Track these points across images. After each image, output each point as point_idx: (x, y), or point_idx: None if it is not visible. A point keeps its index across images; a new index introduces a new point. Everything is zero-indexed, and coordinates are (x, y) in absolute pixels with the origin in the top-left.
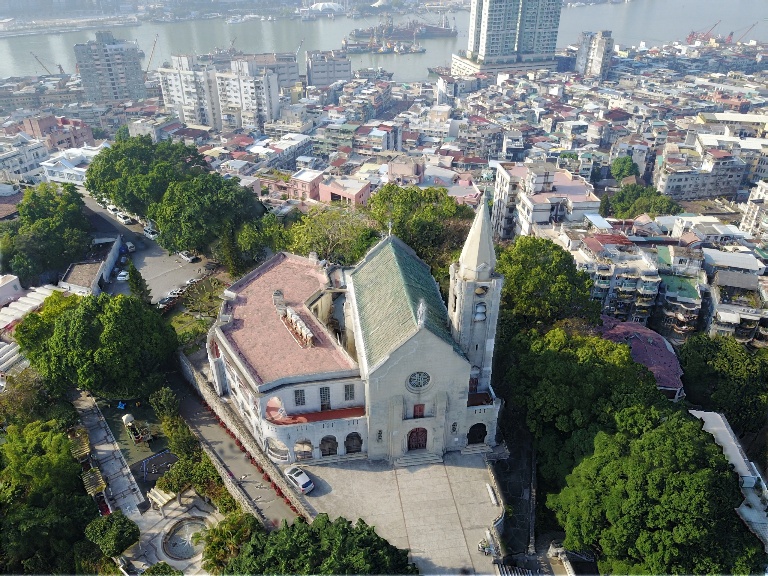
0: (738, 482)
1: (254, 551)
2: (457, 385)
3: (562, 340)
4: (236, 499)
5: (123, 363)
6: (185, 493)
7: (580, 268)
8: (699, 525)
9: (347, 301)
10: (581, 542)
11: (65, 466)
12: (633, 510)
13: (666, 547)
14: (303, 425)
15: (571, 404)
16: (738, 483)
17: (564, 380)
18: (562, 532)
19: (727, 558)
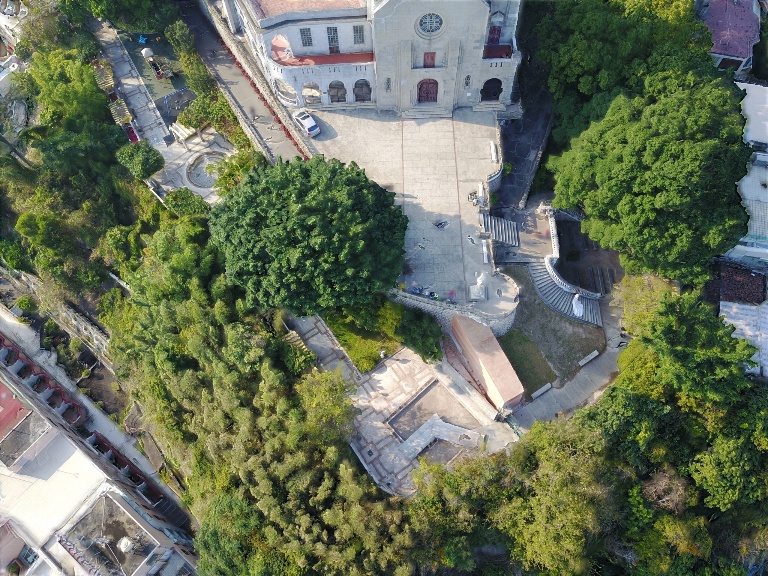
0: None
1: (251, 181)
2: (472, 32)
3: None
4: (249, 138)
5: None
6: (206, 130)
7: None
8: (684, 193)
9: None
10: (568, 201)
11: (91, 95)
12: (622, 174)
13: (645, 211)
14: (309, 67)
15: (600, 63)
16: (748, 158)
17: (599, 35)
18: None
19: (704, 226)
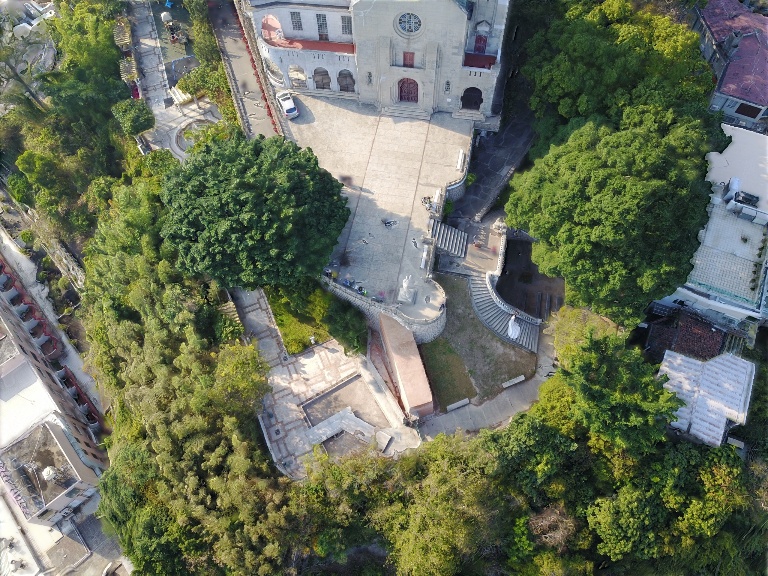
0: (705, 205)
1: (207, 150)
2: (450, 37)
3: (614, 12)
4: None
5: None
6: (205, 98)
7: None
8: (619, 230)
9: None
10: None
11: (103, 49)
12: (563, 201)
13: (581, 242)
14: (294, 51)
15: (582, 88)
16: (704, 206)
17: (586, 59)
18: None
19: (640, 268)
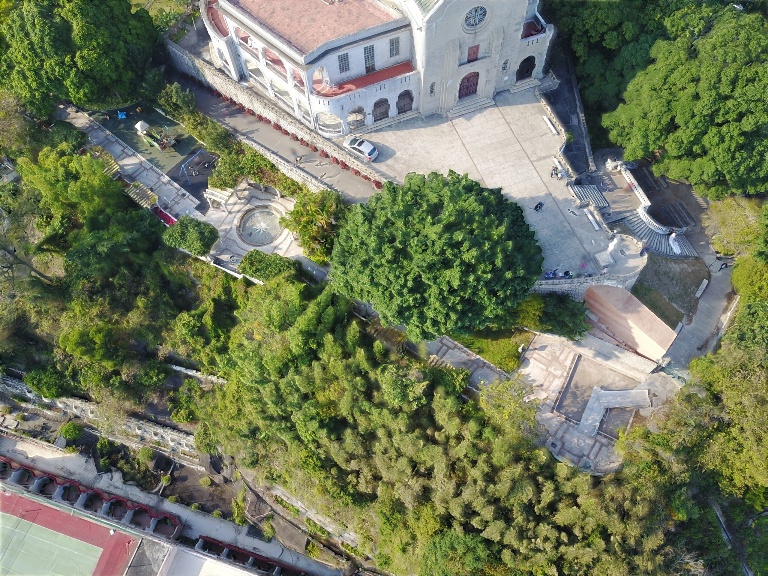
0: None
1: (365, 218)
2: (514, 16)
3: None
4: (300, 181)
5: (112, 64)
6: (237, 187)
7: None
8: None
9: None
10: (645, 150)
11: (107, 186)
12: (706, 109)
13: (733, 137)
14: (356, 92)
15: (620, 17)
16: None
17: None
18: (607, 148)
19: None
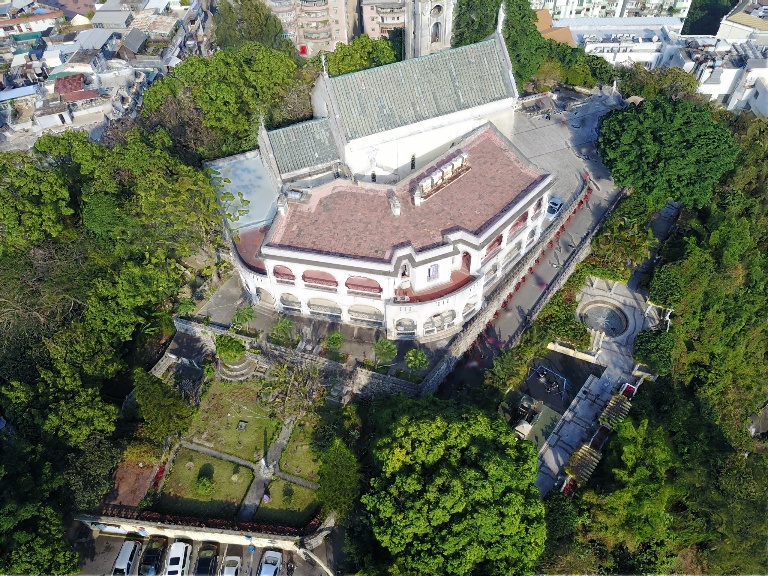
0: None
1: None
2: None
3: None
4: None
5: None
6: None
7: (115, 116)
8: None
9: (380, 151)
10: None
11: None
12: None
13: None
14: None
15: None
16: None
17: None
18: None
19: None
